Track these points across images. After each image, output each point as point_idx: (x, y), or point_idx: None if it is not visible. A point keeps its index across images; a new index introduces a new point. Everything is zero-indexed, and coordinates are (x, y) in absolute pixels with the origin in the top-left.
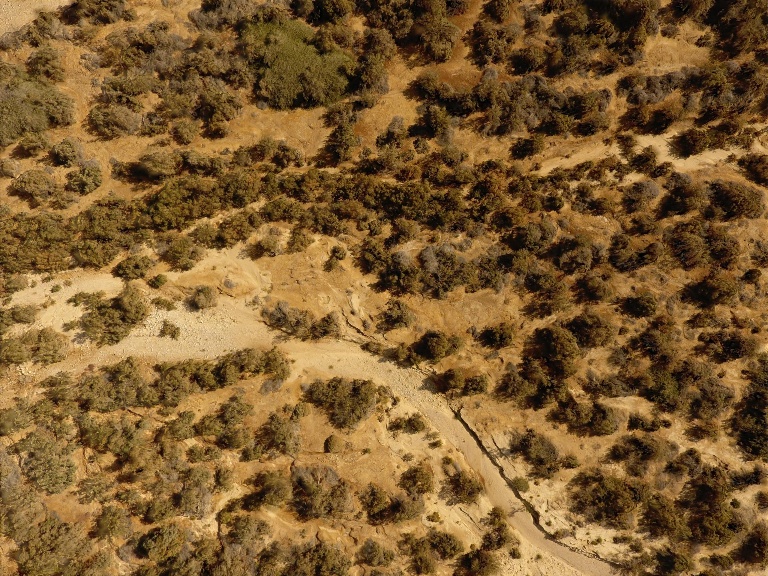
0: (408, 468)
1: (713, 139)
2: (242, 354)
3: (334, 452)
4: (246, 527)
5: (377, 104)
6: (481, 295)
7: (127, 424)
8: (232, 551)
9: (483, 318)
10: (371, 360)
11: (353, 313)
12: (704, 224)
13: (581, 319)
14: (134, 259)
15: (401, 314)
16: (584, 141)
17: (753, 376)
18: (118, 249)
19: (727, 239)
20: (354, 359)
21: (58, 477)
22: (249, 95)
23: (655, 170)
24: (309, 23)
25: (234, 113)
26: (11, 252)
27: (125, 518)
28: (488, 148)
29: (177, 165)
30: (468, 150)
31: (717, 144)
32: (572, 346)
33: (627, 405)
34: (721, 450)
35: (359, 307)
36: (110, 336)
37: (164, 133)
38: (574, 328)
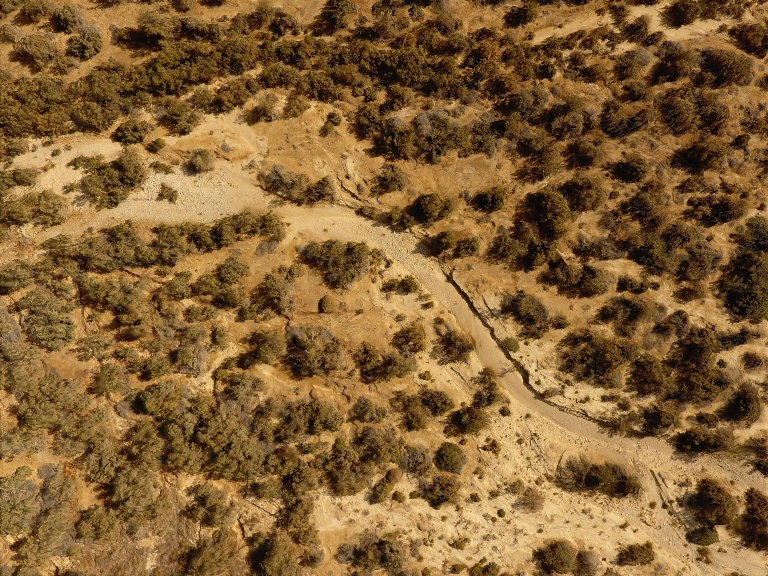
0: (400, 329)
1: (704, 9)
2: (238, 217)
3: (328, 312)
4: (241, 382)
5: None
6: (474, 160)
7: (125, 284)
8: (227, 407)
9: (475, 182)
10: (365, 224)
11: (348, 177)
12: (694, 90)
13: (572, 181)
14: (133, 121)
15: (395, 176)
16: (577, 10)
17: (741, 239)
18: (117, 113)
19: (717, 104)
20: (348, 223)
21: (57, 332)
22: None
23: (647, 38)
24: None
25: None
26: (12, 111)
27: (123, 374)
28: (482, 16)
29: (175, 29)
30: (462, 19)
31: (708, 14)
32: (562, 204)
33: (616, 268)
34: (708, 312)
35: (354, 171)
36: (109, 198)
37: (163, 0)
38: (565, 191)
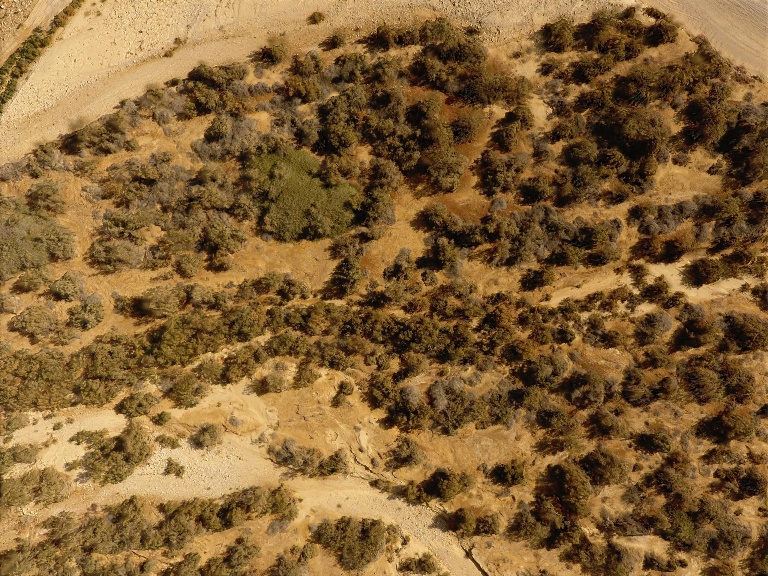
0: None
1: (726, 269)
2: (248, 492)
3: None
4: None
5: (384, 236)
6: (492, 431)
7: (131, 567)
8: None
9: (494, 455)
10: (380, 497)
11: (361, 451)
12: (718, 358)
13: (594, 458)
14: (137, 398)
15: (410, 453)
16: (595, 271)
17: None
18: (121, 386)
19: (742, 374)
20: (363, 497)
21: None
22: (253, 227)
23: (668, 301)
24: (314, 152)
25: (238, 246)
26: (12, 394)
27: None
28: (497, 280)
29: (181, 302)
30: (477, 281)
31: (730, 273)
32: (586, 490)
33: (642, 544)
34: None
35: (367, 444)
36: (113, 476)
37: (167, 266)
38: (587, 466)
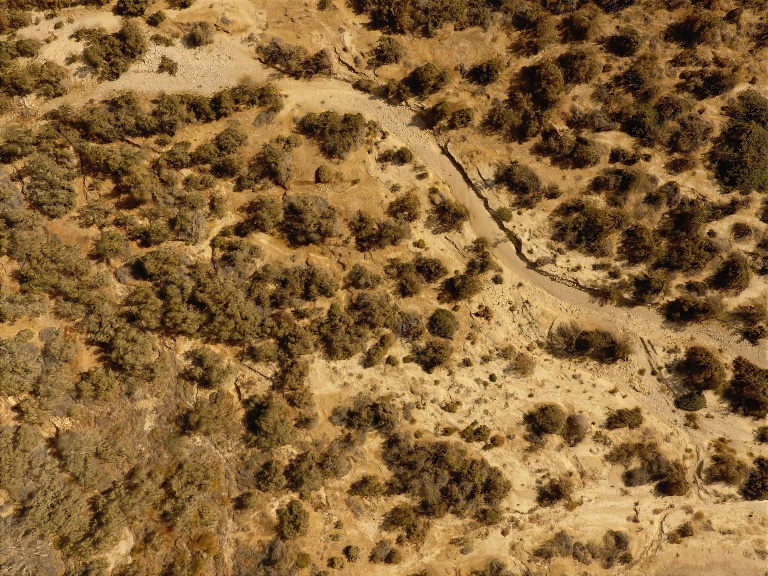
0: (396, 199)
1: None
2: (237, 90)
3: (324, 182)
4: (239, 248)
5: None
6: (469, 33)
7: (126, 153)
8: (225, 273)
9: (471, 56)
10: (362, 97)
11: (345, 49)
12: None
13: (566, 53)
14: None
15: (391, 47)
16: None
17: (732, 112)
18: None
19: None
20: (345, 96)
21: (59, 198)
22: None
23: None
24: None
25: None
26: None
27: (123, 241)
28: None
29: None
30: None
31: None
32: (556, 71)
33: (609, 140)
34: (699, 183)
35: (351, 44)
36: (110, 70)
37: None
38: (559, 63)
